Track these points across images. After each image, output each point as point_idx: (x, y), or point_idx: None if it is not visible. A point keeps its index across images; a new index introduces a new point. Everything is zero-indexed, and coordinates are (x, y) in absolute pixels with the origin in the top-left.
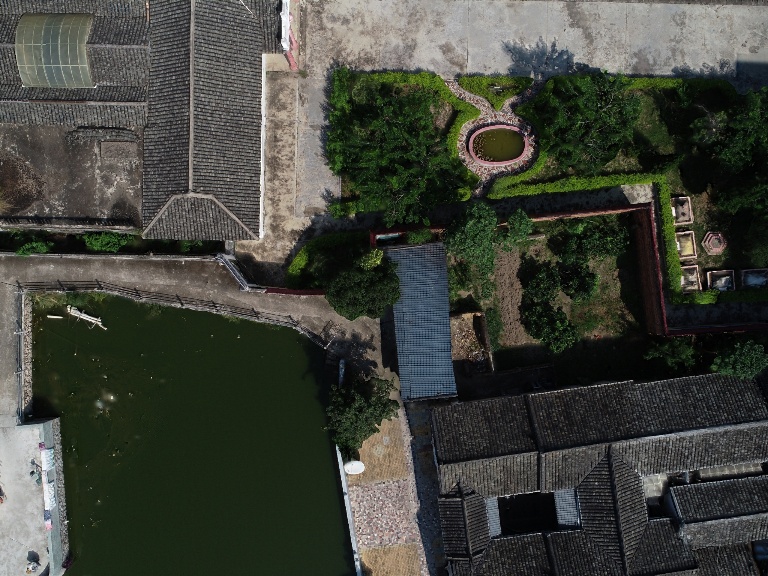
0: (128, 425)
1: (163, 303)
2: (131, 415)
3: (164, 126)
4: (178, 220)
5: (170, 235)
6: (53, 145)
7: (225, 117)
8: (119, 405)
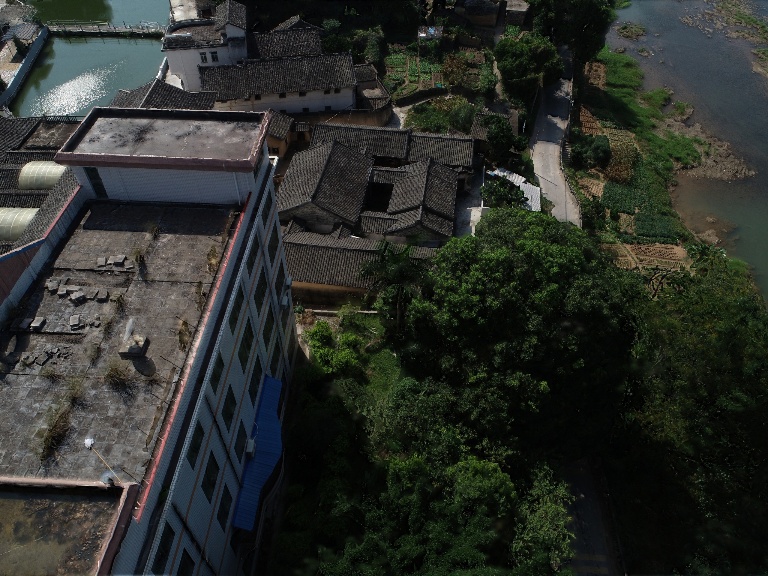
0: None
1: None
2: None
3: (1, 144)
4: None
5: None
6: None
7: None
8: None
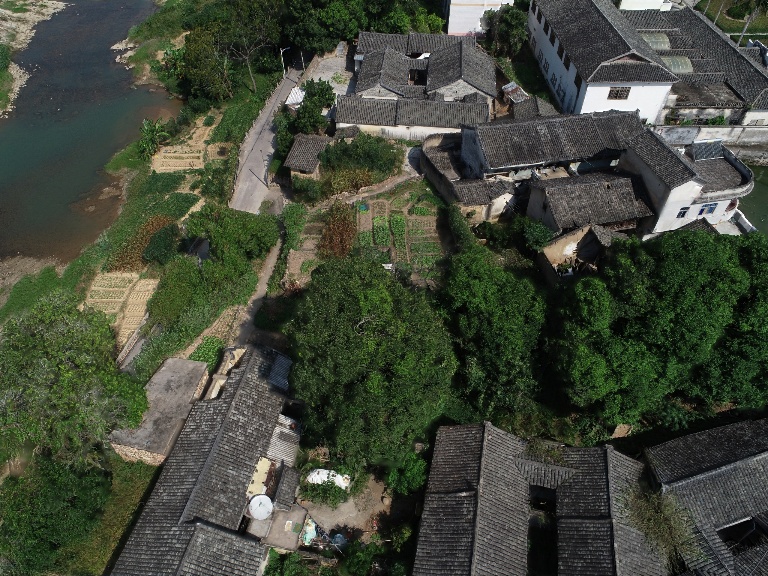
0: (760, 209)
1: (749, 159)
2: (760, 205)
3: None
4: (767, 100)
5: (764, 107)
6: (684, 87)
7: (766, 74)
8: (749, 201)
